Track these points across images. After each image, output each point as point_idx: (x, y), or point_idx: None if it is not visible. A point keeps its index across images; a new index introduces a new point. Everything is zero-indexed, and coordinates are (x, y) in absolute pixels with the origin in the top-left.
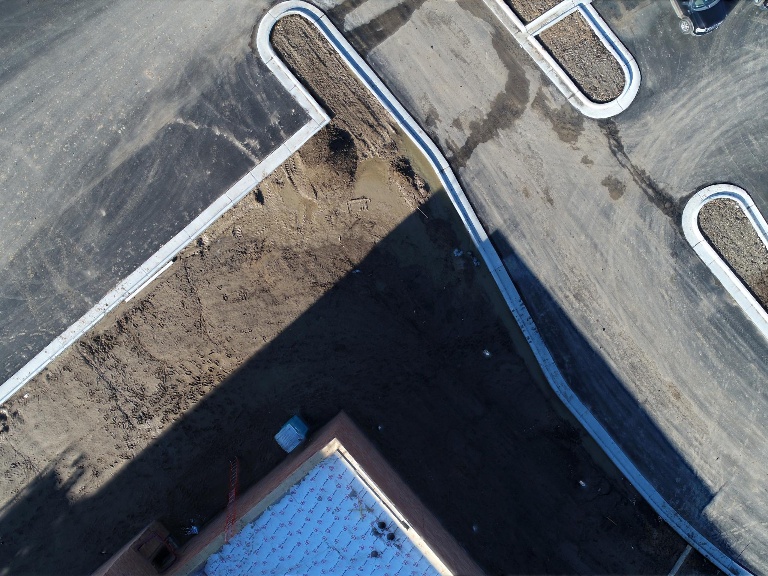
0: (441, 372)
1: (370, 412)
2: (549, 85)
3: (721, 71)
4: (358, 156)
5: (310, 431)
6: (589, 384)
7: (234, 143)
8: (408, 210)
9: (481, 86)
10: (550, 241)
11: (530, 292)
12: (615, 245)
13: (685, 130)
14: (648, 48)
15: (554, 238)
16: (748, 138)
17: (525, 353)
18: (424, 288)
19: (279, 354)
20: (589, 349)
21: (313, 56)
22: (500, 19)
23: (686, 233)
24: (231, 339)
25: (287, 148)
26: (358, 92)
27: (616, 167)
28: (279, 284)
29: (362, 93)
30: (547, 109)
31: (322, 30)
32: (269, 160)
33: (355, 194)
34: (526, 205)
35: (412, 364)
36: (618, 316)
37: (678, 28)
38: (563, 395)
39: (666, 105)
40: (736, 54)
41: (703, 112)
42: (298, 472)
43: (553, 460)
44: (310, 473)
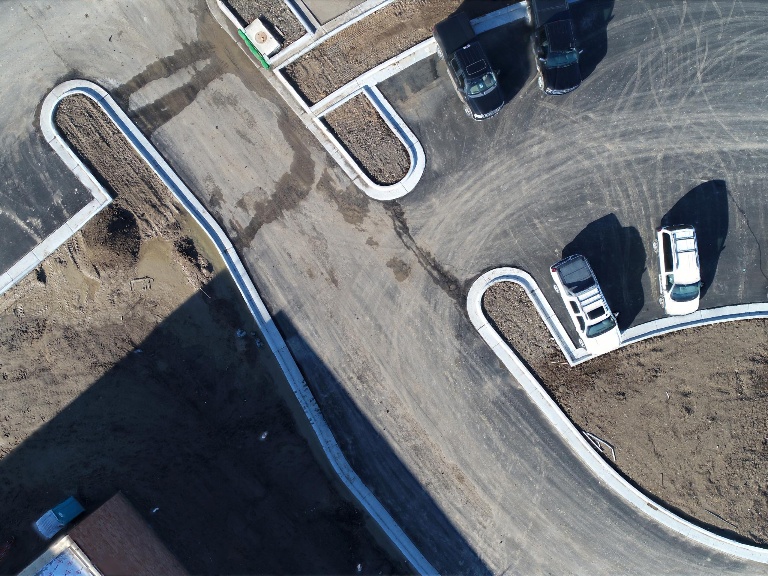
0: (222, 453)
1: (149, 493)
2: (334, 166)
3: (506, 154)
4: (141, 236)
5: (85, 512)
6: (372, 466)
7: (16, 221)
8: (191, 290)
9: (266, 167)
10: (334, 322)
11: (314, 373)
12: (400, 327)
13: (470, 213)
14: (433, 131)
15: (338, 319)
16: (533, 222)
17: (308, 434)
18: (206, 368)
19: (58, 434)
20: (373, 431)
21: (96, 136)
22: (285, 100)
23: (471, 316)
24: (10, 418)
25: (69, 227)
26: (141, 172)
27: (401, 249)
28: (60, 363)
29: (145, 173)
30: (332, 190)
31: (105, 110)
32: (51, 239)
33: (138, 273)
34: (310, 286)
35: (193, 445)
36: (402, 398)
37: (463, 111)
38: (346, 477)
39: (451, 188)
40: (521, 138)
41: (488, 195)
42: (30, 569)
43: (334, 542)
44: (48, 568)
